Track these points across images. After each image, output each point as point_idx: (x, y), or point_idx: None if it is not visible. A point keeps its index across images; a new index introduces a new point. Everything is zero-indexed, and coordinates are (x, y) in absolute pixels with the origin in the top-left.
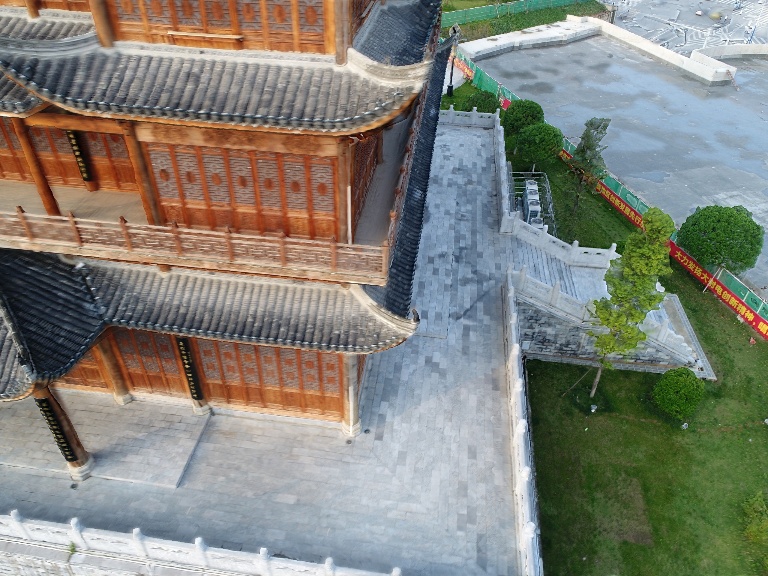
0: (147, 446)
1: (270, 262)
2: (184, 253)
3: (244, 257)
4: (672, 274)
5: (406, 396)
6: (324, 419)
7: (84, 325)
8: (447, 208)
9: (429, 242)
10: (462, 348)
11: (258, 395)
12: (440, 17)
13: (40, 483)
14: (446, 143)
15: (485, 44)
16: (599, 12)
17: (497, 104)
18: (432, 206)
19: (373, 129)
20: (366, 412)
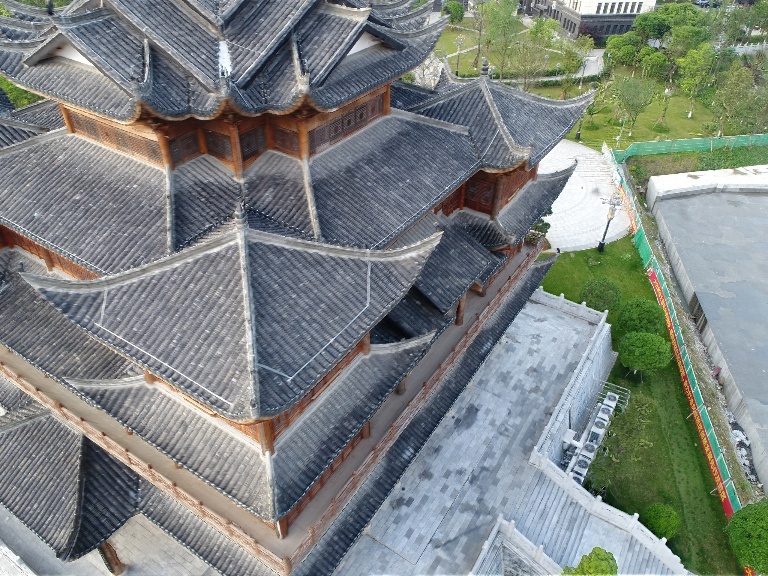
0: (162, 574)
1: (224, 529)
2: (180, 498)
3: (210, 518)
4: (718, 551)
5: None
6: None
7: (123, 510)
8: (495, 417)
9: (457, 453)
10: None
11: None
12: (538, 245)
13: (94, 574)
14: (541, 333)
15: (681, 182)
16: None
17: (615, 298)
18: (483, 410)
19: None
20: None
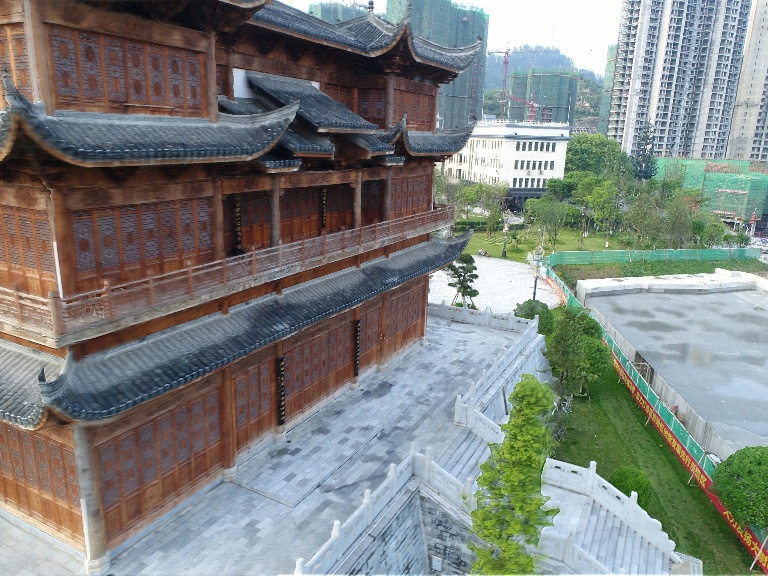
0: None
1: None
2: None
3: None
4: (711, 535)
5: (189, 553)
6: (75, 546)
7: None
8: (413, 390)
9: (363, 414)
10: (301, 522)
11: (26, 497)
12: (447, 209)
13: None
14: (467, 339)
15: (607, 283)
16: (761, 270)
17: (546, 314)
18: (398, 385)
19: (6, 157)
20: (131, 556)
